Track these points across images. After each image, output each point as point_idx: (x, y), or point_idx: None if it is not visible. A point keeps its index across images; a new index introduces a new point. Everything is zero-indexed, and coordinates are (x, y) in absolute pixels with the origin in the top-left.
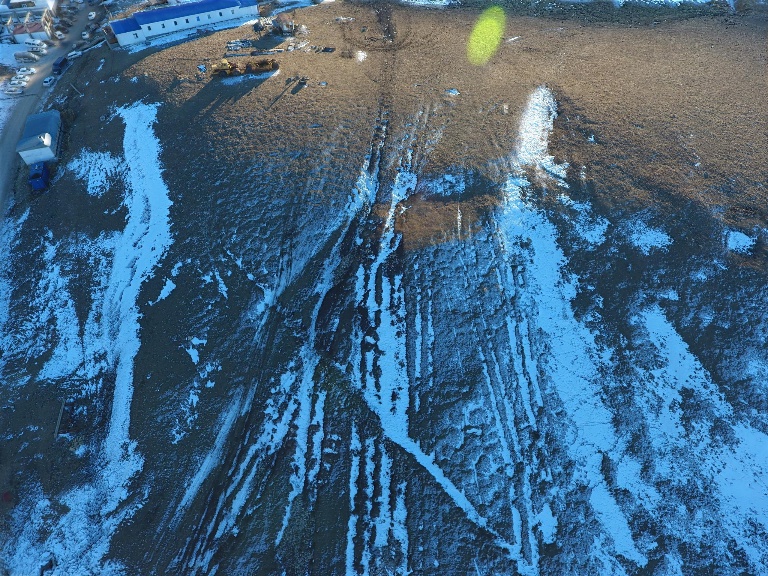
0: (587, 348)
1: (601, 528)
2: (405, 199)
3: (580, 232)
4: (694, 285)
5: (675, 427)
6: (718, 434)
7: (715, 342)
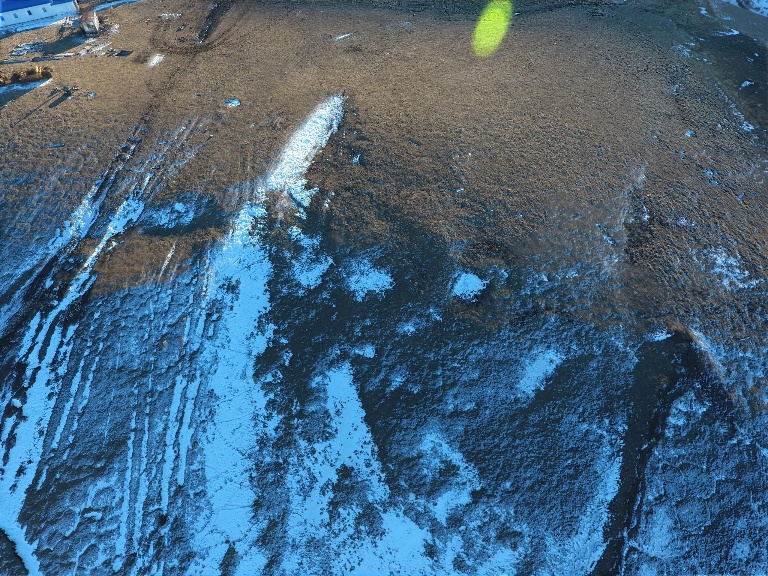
0: (255, 415)
1: None
2: (120, 232)
3: (296, 273)
4: (397, 339)
5: (319, 513)
6: (363, 523)
7: (396, 410)
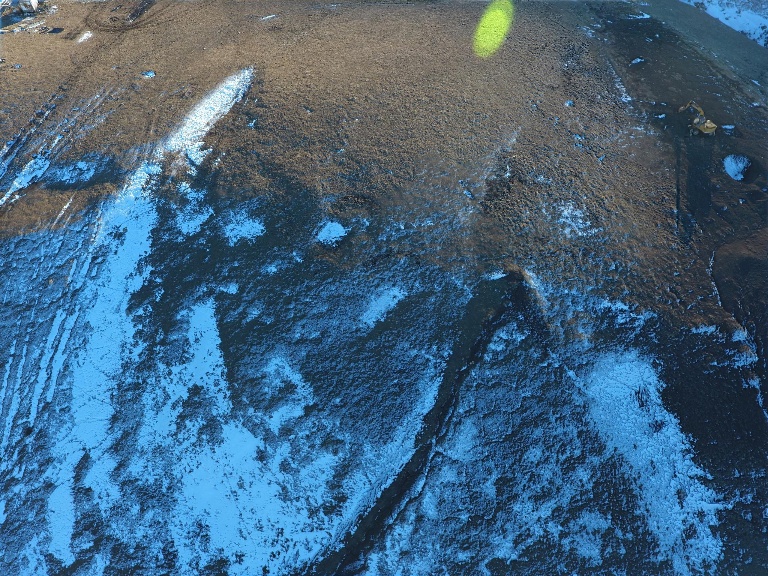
0: (123, 343)
1: (45, 526)
2: (24, 187)
3: (179, 222)
4: (259, 278)
5: (168, 425)
6: (205, 433)
7: (248, 338)
